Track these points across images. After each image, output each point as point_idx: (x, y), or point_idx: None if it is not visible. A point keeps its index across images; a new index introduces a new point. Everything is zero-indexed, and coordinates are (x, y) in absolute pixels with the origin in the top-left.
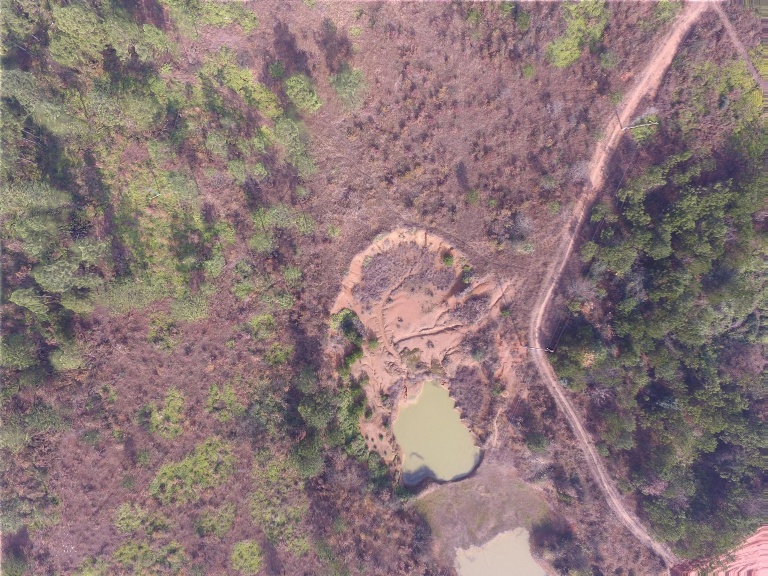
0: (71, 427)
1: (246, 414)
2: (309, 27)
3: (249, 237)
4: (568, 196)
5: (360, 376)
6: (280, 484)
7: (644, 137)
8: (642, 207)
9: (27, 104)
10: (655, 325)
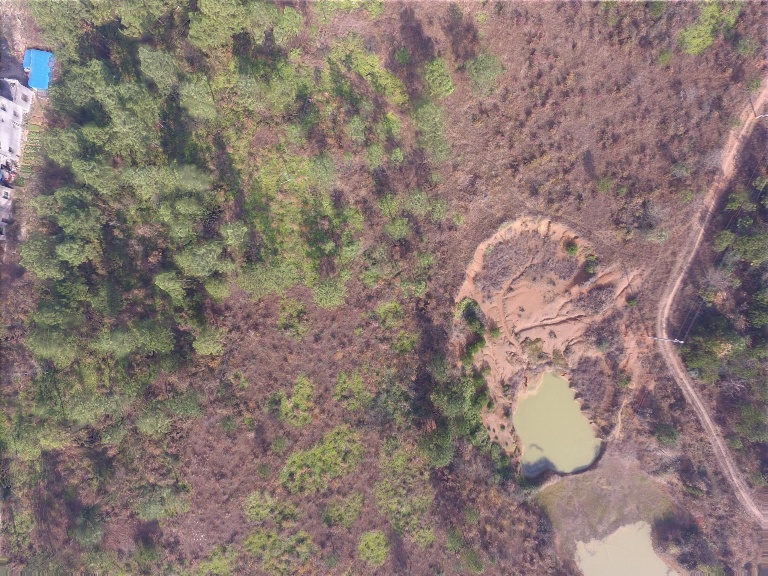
0: (203, 414)
1: (374, 403)
2: (435, 13)
3: (377, 224)
4: (699, 185)
5: (481, 366)
6: (406, 474)
7: None
8: None
9: (164, 87)
10: None
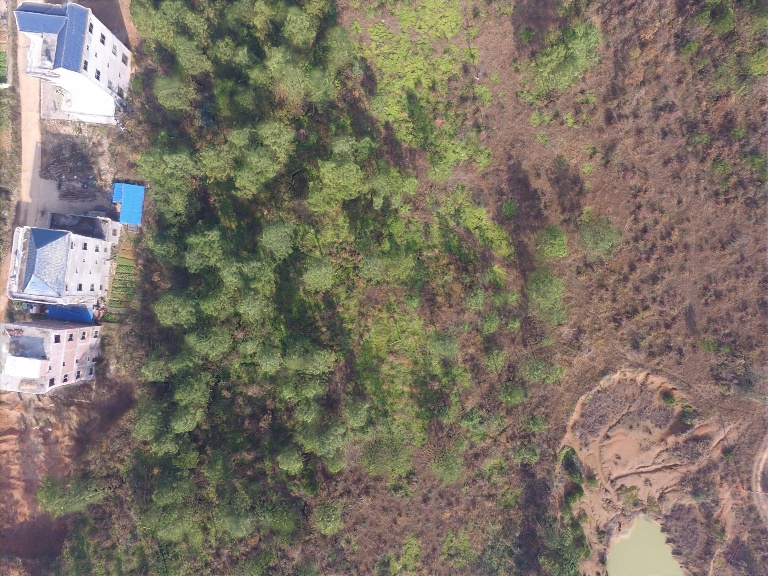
0: None
1: (479, 560)
2: (542, 164)
3: (484, 381)
4: None
5: (578, 513)
6: None
7: None
8: None
9: (281, 254)
10: None
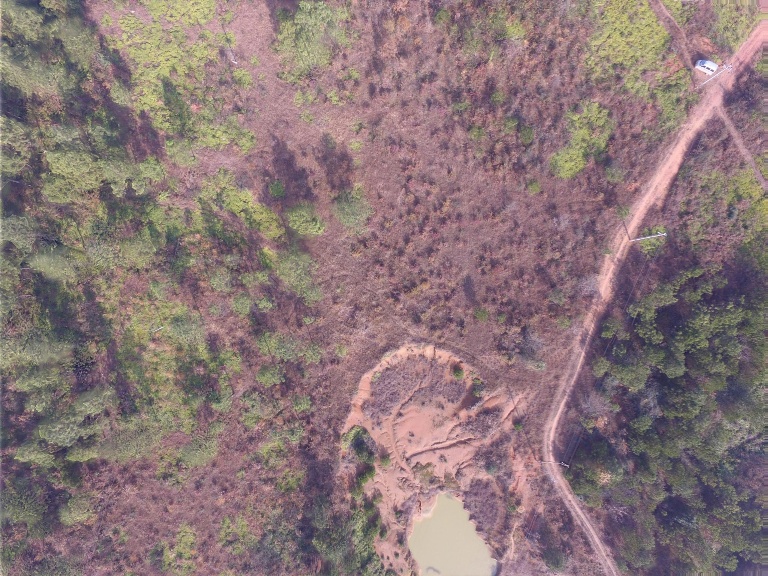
0: (82, 572)
1: (260, 545)
2: (308, 143)
3: (255, 364)
4: (578, 309)
5: (373, 494)
6: None
7: (653, 248)
8: (654, 325)
9: (23, 247)
10: (671, 443)
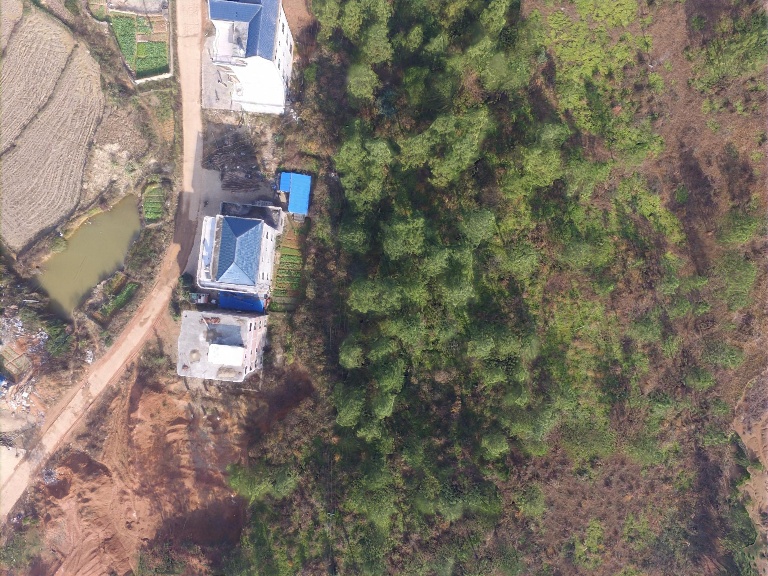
0: (507, 562)
1: (658, 542)
2: (712, 151)
3: (660, 366)
4: None
5: (742, 496)
6: None
7: None
8: None
9: None
10: None
